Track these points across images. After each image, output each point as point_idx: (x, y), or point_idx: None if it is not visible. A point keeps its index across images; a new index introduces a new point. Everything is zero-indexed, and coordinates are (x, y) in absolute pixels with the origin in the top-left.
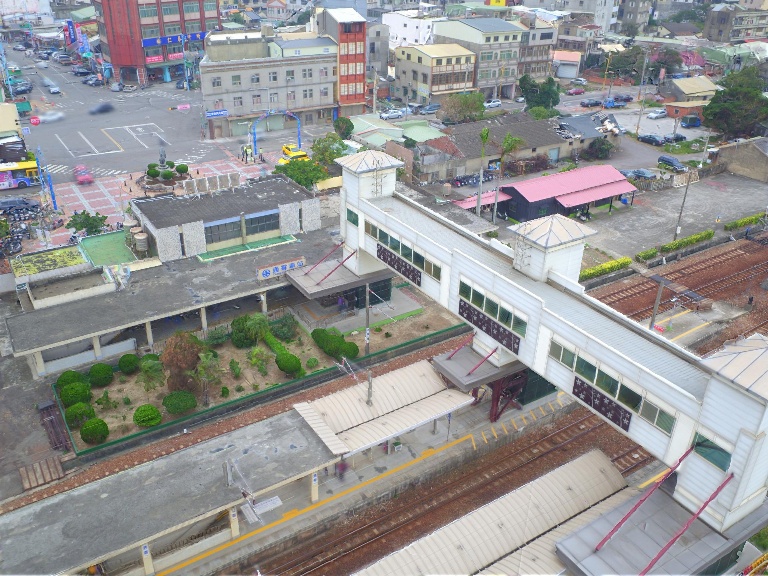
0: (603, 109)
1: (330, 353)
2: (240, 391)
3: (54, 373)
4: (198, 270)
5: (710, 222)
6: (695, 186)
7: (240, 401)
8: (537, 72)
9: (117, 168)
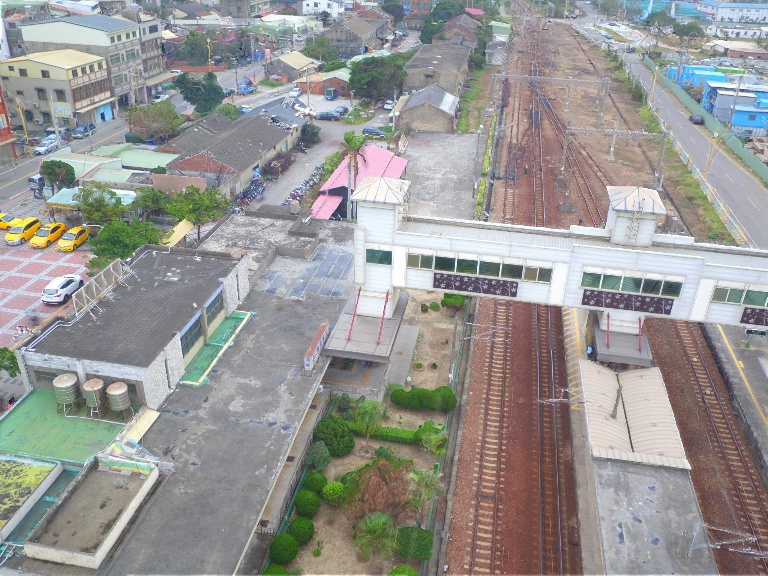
0: (242, 96)
1: (440, 407)
2: None
3: None
4: (214, 396)
5: (467, 173)
6: (412, 148)
7: None
8: (153, 69)
9: None
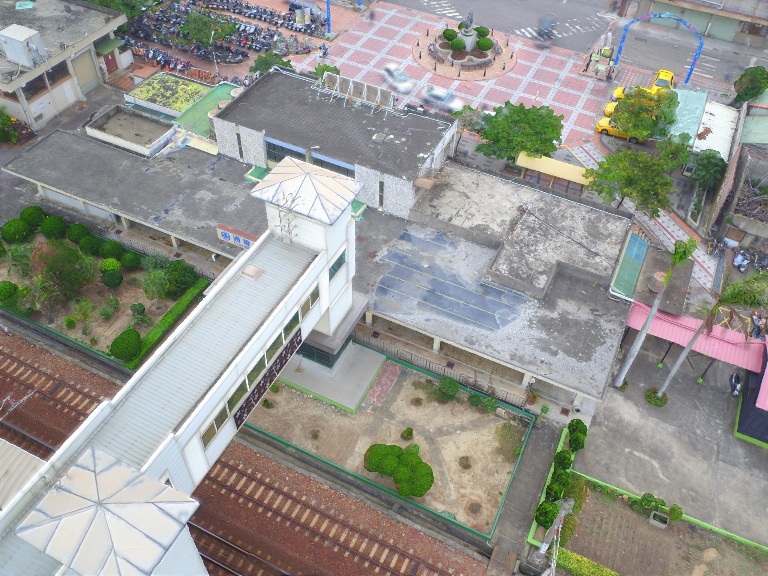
0: None
1: None
2: (83, 333)
3: (50, 200)
4: (224, 183)
5: None
6: None
7: (72, 342)
8: None
9: (461, 9)
